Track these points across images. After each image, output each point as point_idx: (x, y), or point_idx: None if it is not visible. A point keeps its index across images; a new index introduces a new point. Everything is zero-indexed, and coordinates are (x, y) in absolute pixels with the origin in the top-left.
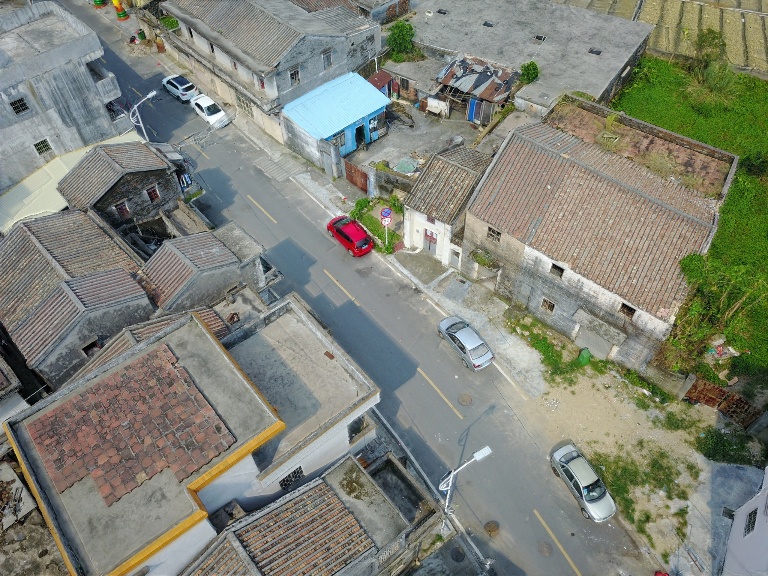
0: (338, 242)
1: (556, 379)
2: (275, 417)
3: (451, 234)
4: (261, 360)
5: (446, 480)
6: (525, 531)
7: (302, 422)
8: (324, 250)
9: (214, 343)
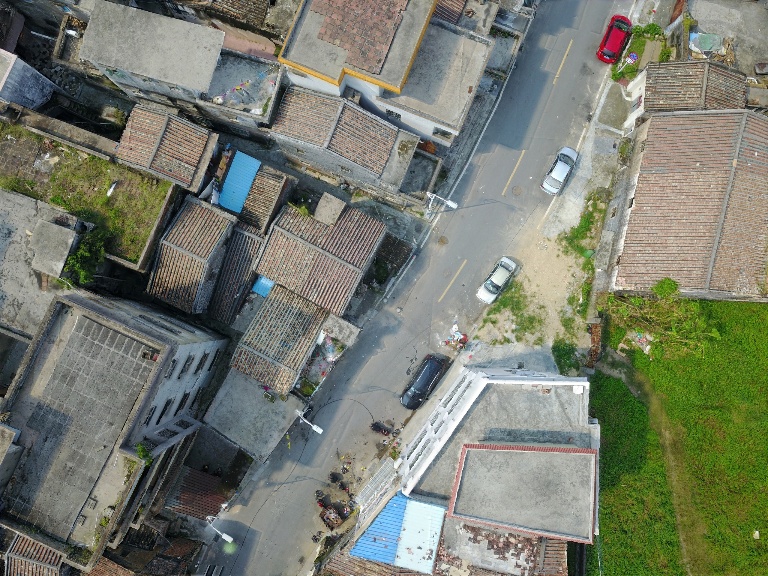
0: (605, 34)
1: (563, 242)
2: (400, 86)
3: (641, 115)
4: (446, 52)
5: (430, 193)
6: (451, 259)
7: (421, 100)
8: (591, 28)
9: (424, 23)
